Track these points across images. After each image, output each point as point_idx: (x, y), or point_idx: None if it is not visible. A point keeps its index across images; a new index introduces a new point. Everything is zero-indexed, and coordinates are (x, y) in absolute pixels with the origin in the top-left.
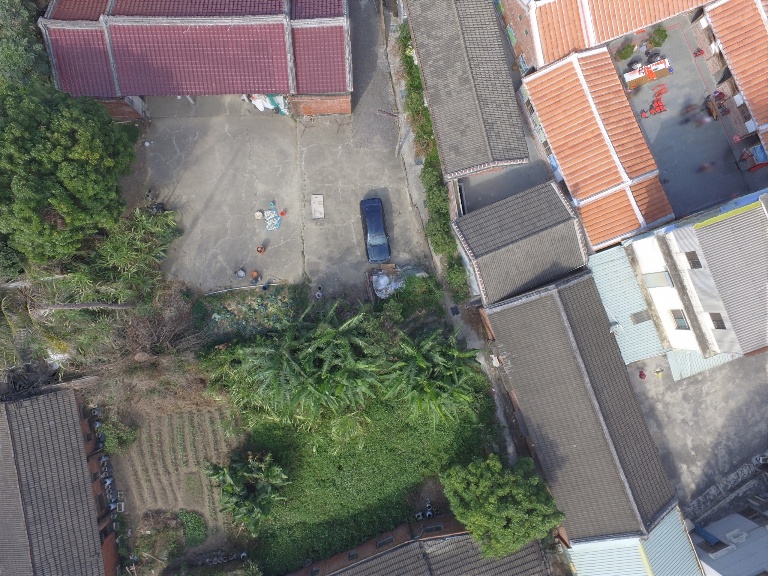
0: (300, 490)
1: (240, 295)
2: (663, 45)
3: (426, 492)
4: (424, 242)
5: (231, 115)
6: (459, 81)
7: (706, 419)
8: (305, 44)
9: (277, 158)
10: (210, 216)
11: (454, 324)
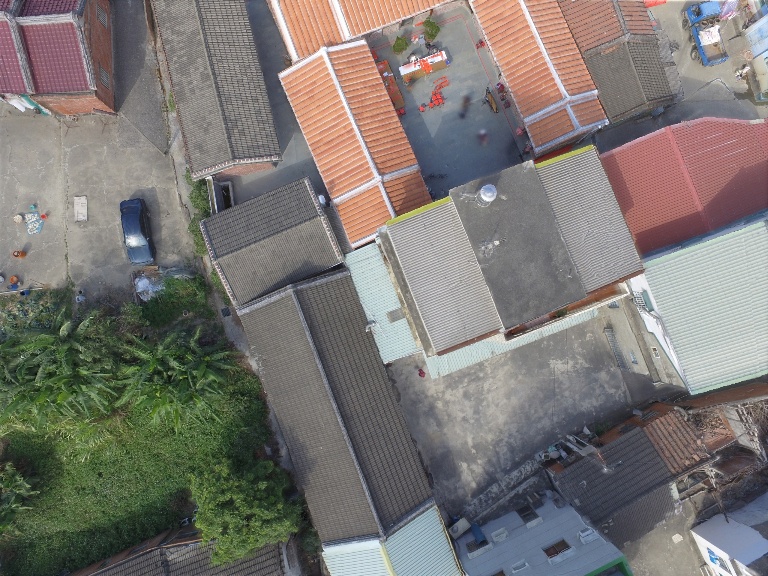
0: (58, 498)
1: None
2: (445, 37)
3: None
4: (193, 243)
5: None
6: (201, 77)
7: (487, 416)
8: (38, 42)
9: (39, 159)
10: None
11: (225, 326)
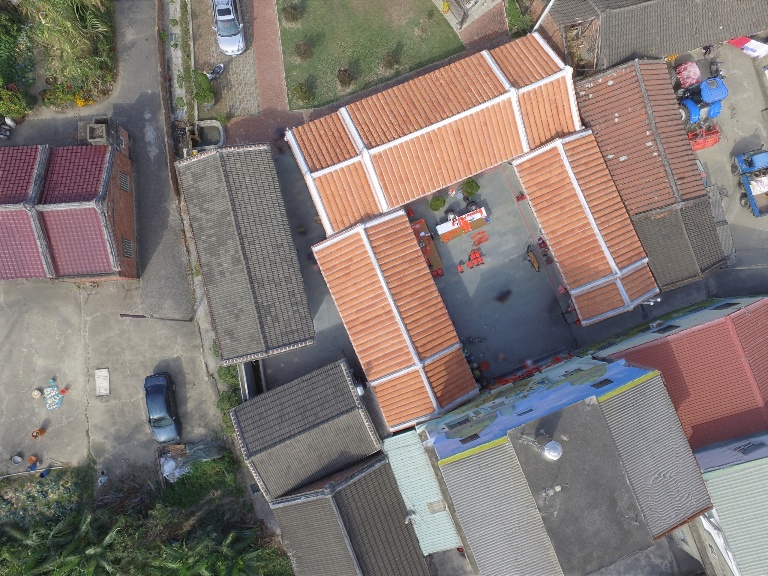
0: None
1: (18, 481)
2: (484, 189)
3: None
4: (221, 415)
5: (7, 284)
6: (232, 260)
7: None
8: (58, 226)
9: (58, 329)
10: None
11: (254, 503)
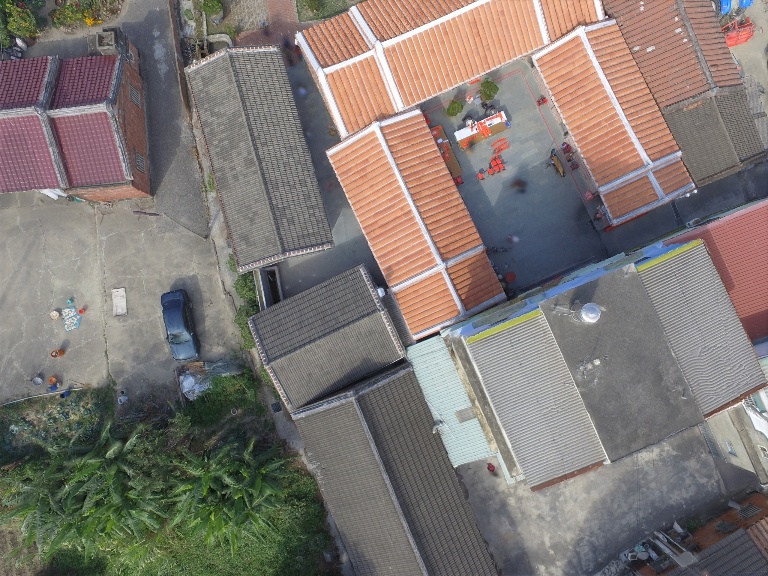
0: None
1: (39, 403)
2: (502, 94)
3: None
4: (239, 333)
5: (22, 206)
6: (245, 163)
7: (565, 513)
8: (70, 134)
9: (74, 250)
10: (3, 319)
11: (276, 422)
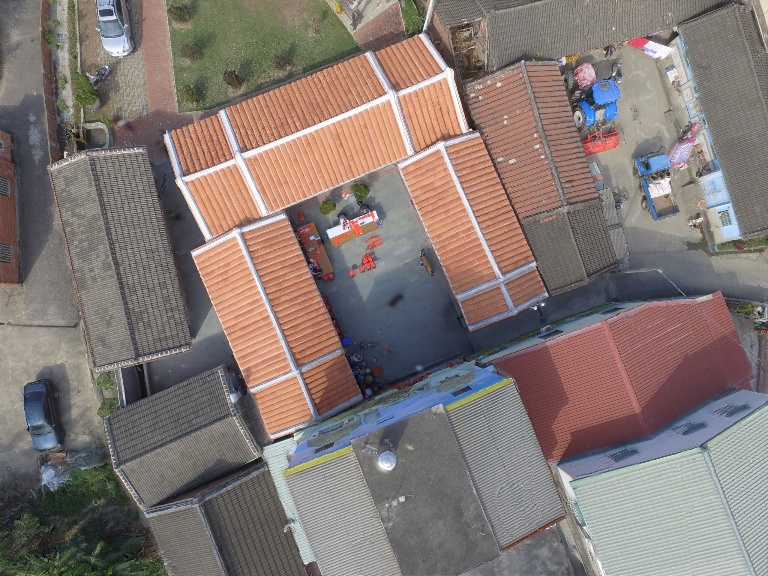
0: None
1: None
2: (378, 192)
3: None
4: None
5: None
6: (103, 266)
7: None
8: None
9: None
10: None
11: (140, 511)
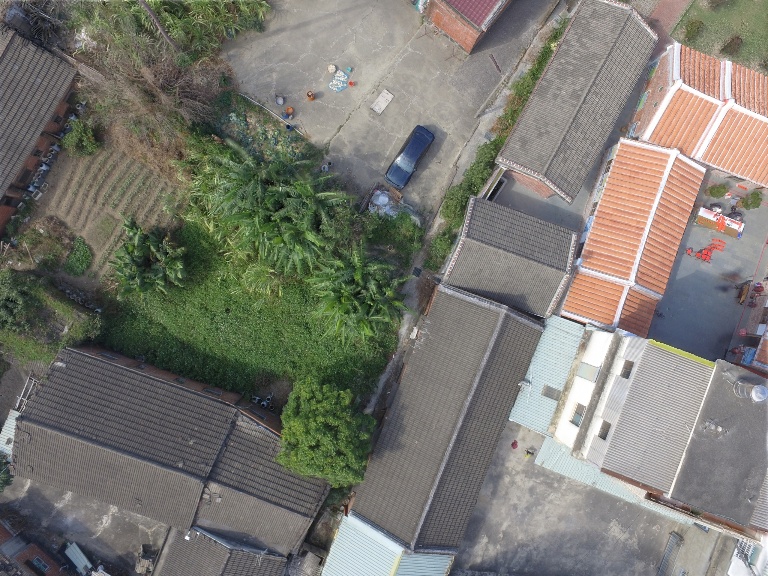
0: (183, 300)
1: (265, 116)
2: (751, 213)
3: (276, 387)
4: (439, 200)
5: None
6: (572, 93)
7: (533, 519)
8: None
9: (384, 38)
10: (295, 37)
11: (407, 281)
